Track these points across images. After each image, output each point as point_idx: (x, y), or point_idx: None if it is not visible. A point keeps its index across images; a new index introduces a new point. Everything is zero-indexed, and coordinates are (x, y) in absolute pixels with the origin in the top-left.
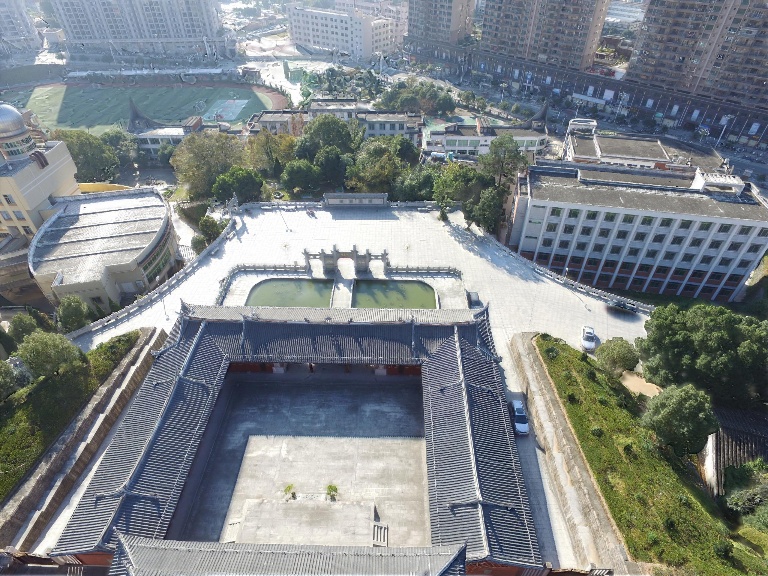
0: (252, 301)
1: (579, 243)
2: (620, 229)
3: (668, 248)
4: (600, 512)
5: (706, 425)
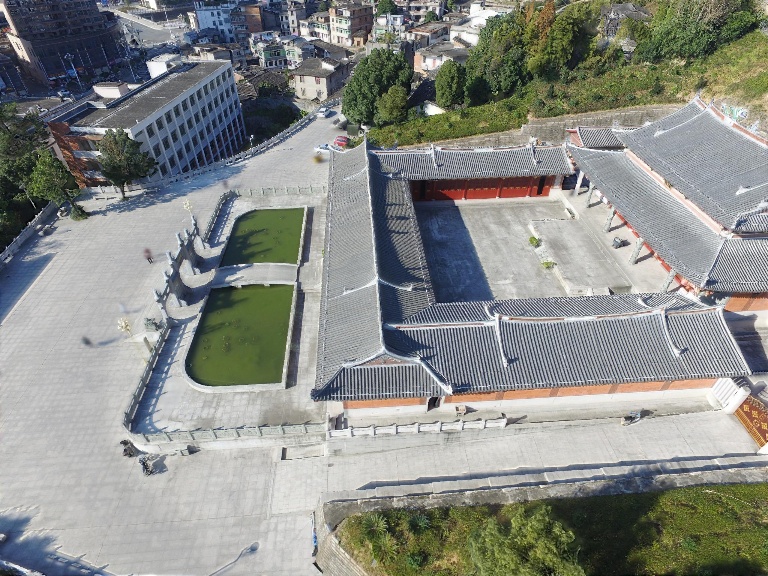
0: (243, 380)
1: (178, 153)
2: (186, 119)
3: (210, 118)
4: (500, 135)
5: (465, 69)
